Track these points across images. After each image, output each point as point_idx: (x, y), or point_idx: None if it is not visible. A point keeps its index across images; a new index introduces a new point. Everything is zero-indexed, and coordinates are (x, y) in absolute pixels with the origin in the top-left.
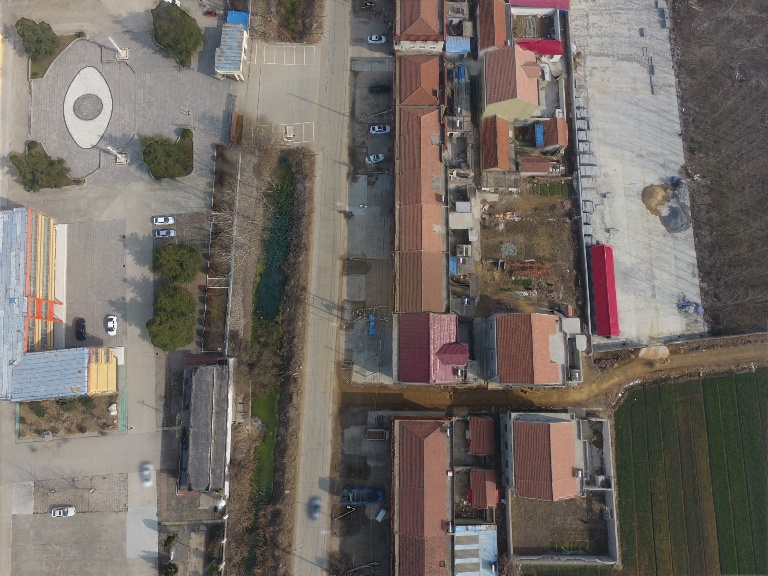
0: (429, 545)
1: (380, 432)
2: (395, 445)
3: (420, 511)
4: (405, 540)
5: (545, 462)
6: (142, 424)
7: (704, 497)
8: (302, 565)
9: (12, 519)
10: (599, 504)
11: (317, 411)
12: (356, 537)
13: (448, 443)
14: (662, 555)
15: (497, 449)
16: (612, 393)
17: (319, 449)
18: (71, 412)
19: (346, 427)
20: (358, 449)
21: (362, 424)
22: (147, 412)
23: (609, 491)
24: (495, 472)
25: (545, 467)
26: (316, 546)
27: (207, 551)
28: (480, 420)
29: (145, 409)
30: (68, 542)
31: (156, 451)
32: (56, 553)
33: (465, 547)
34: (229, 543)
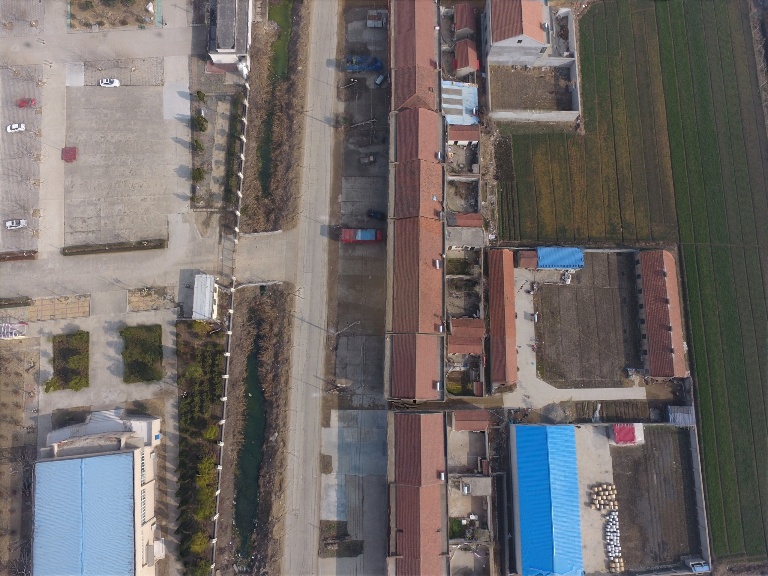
0: (420, 71)
1: (378, 15)
2: (391, 3)
3: (412, 47)
4: (400, 72)
5: (517, 9)
6: (175, 21)
7: (655, 83)
8: (313, 123)
9: (66, 89)
10: (565, 81)
11: (325, 11)
12: (358, 101)
13: (436, 7)
14: (619, 124)
15: (478, 39)
16: (577, 2)
17: (326, 39)
18: (114, 11)
19: (349, 22)
20: (360, 38)
21: (363, 19)
22: (179, 13)
23: (573, 63)
24: (476, 46)
25: (517, 13)
26: (325, 109)
27: (232, 114)
28: (463, 4)
29: (177, 10)
30: (114, 107)
31: (187, 41)
32: (104, 115)
33: (451, 96)
34: (251, 108)
